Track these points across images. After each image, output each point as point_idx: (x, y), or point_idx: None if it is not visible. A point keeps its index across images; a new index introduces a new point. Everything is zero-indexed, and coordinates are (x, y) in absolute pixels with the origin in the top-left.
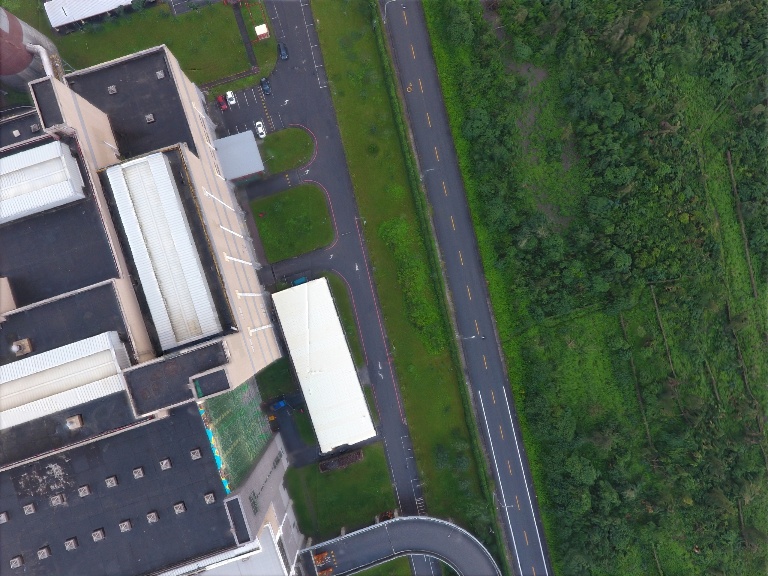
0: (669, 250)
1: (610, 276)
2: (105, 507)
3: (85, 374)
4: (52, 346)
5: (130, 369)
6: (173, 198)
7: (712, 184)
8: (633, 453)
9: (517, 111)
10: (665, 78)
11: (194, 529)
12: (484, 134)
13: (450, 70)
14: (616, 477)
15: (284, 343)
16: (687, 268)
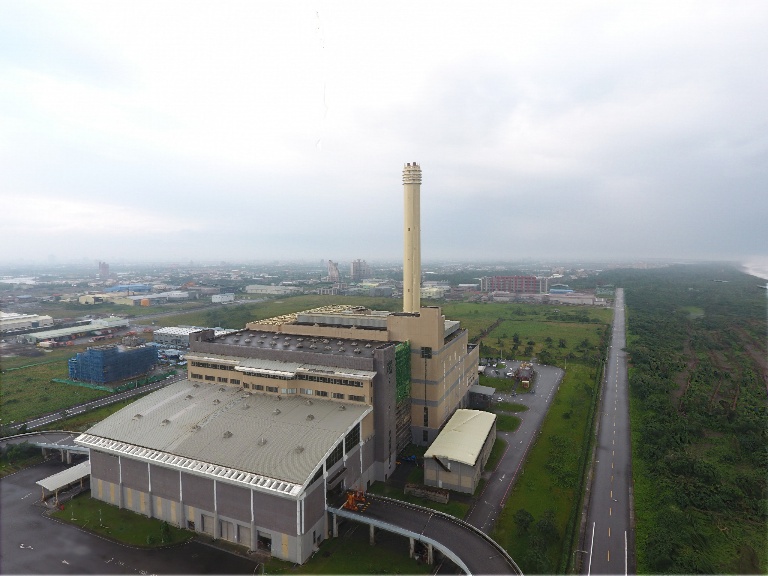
0: None
1: None
2: None
3: None
4: None
5: None
6: (454, 324)
7: None
8: None
9: None
10: None
11: None
12: (655, 428)
13: None
14: None
15: None
16: None
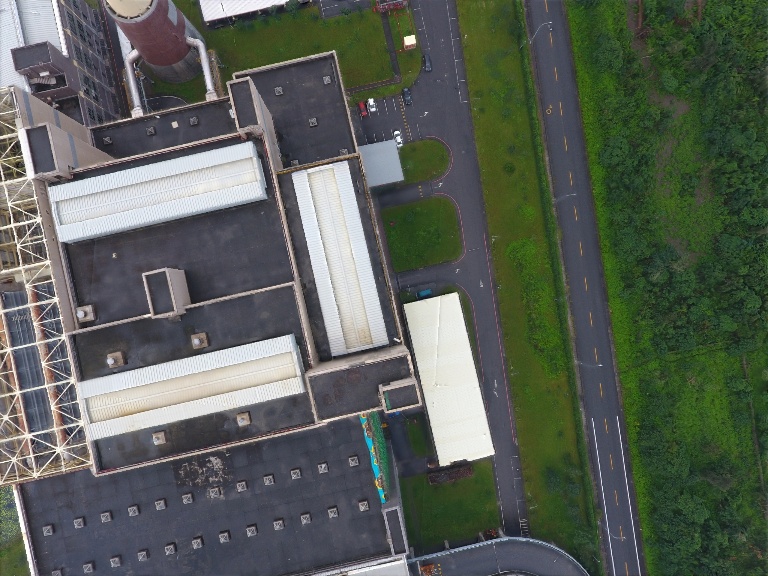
0: None
1: (739, 317)
2: (260, 504)
3: (264, 374)
4: (227, 342)
5: (315, 374)
6: (355, 207)
7: None
8: (744, 496)
9: None
10: None
11: (345, 534)
12: (623, 163)
13: (592, 95)
14: (726, 519)
15: (411, 354)
16: None
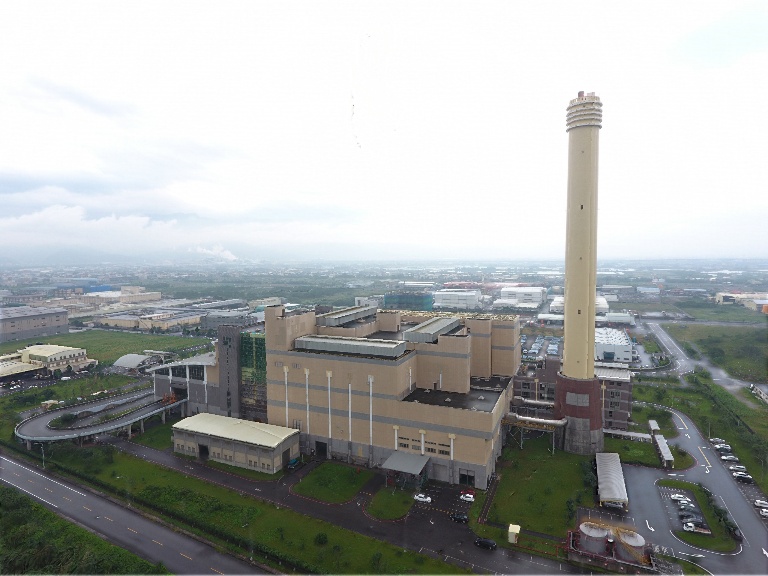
0: None
1: None
2: None
3: None
4: (353, 324)
5: None
6: None
7: None
8: None
9: None
10: None
11: None
12: None
13: None
14: None
15: None
16: None
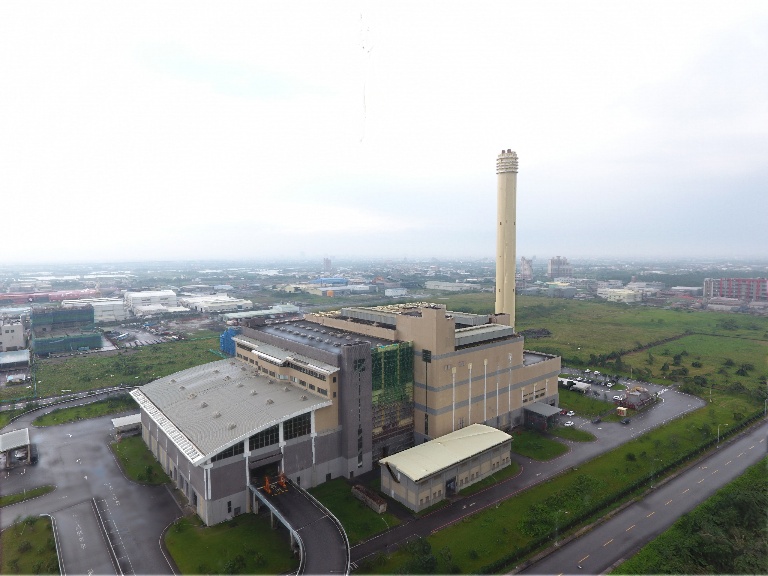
0: None
1: None
2: None
3: None
4: None
5: None
6: None
7: None
8: None
9: None
10: None
11: None
12: None
13: None
14: None
15: None
16: None
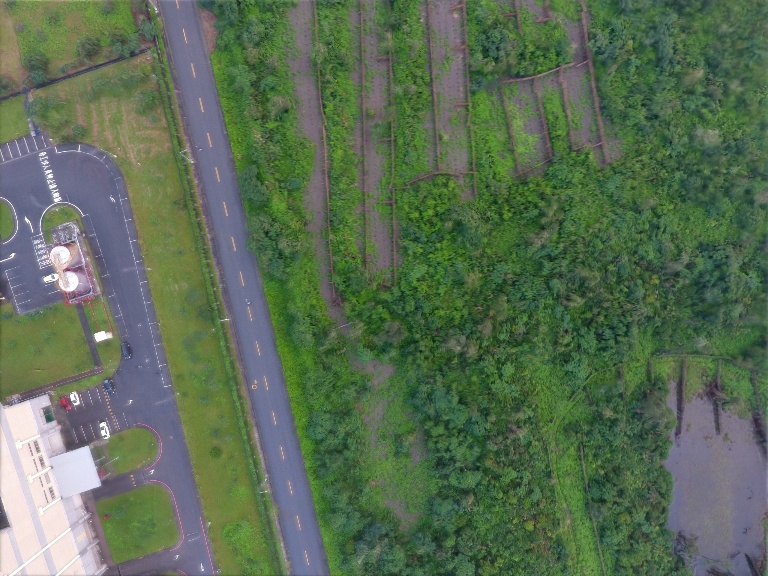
0: (513, 559)
1: None
2: None
3: None
4: None
5: None
6: None
7: (564, 480)
8: None
9: (364, 408)
10: (516, 371)
11: None
12: (325, 441)
13: (295, 368)
14: None
15: None
16: (533, 574)
